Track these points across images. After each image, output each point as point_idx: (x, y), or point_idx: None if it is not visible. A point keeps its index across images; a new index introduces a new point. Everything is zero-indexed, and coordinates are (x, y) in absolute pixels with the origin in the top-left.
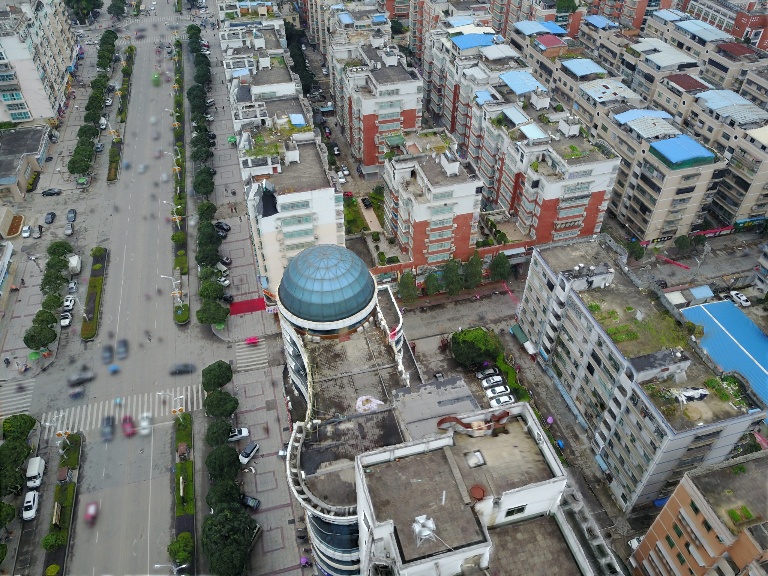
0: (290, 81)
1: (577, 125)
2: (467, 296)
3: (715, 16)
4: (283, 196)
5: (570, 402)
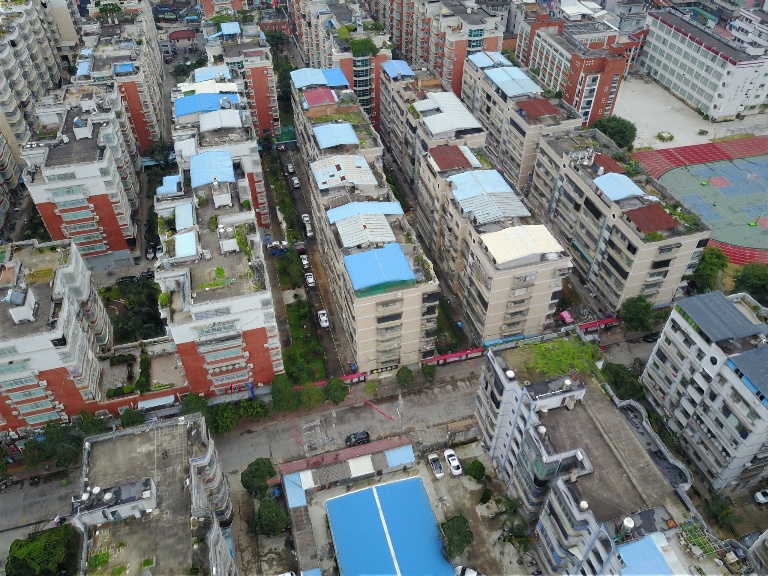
0: None
1: (231, 240)
2: None
3: (554, 56)
4: None
5: None
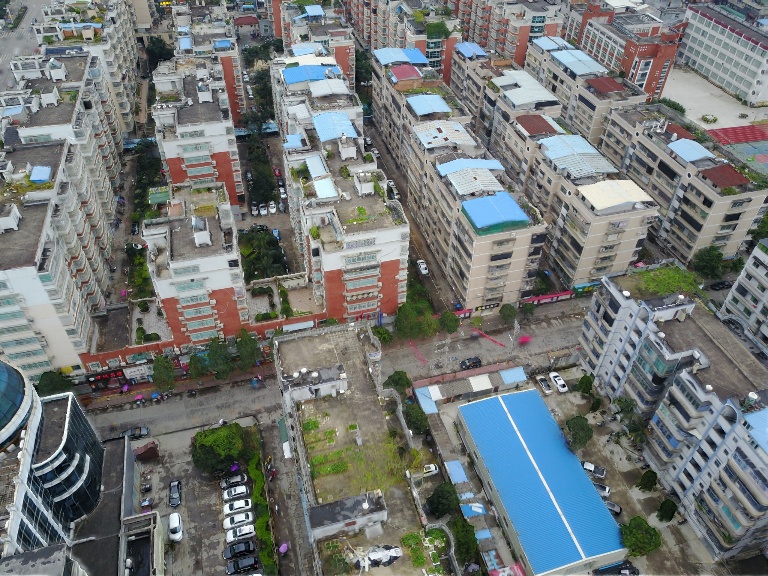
0: (70, 121)
1: (370, 183)
2: (248, 376)
3: (607, 43)
4: None
5: None
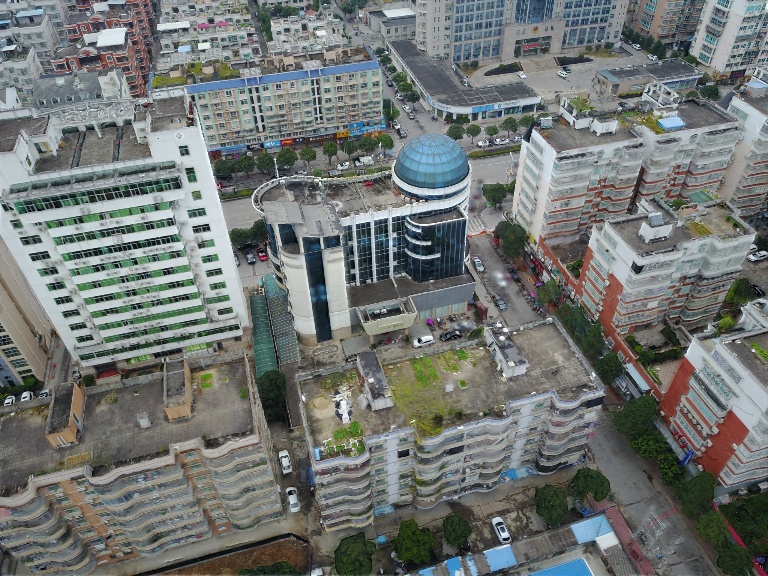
0: None
1: None
2: None
3: None
4: (535, 131)
5: None
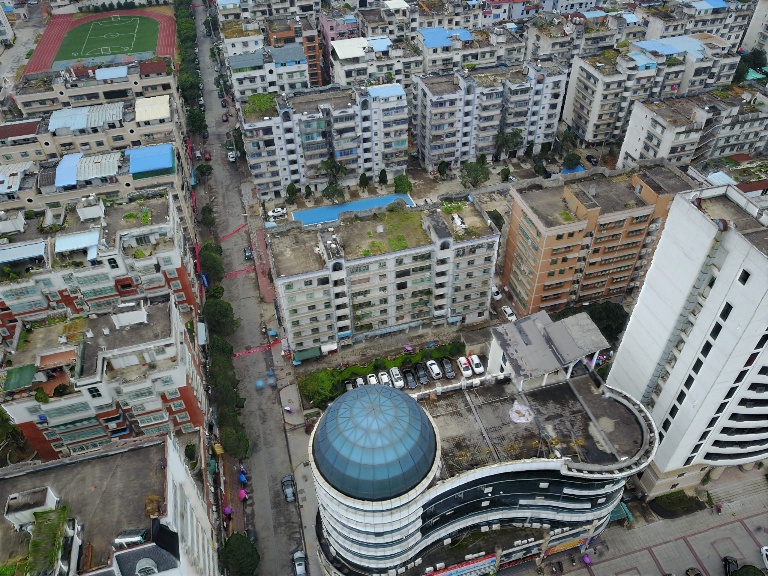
0: None
1: (100, 200)
2: None
3: None
4: (168, 508)
5: (395, 328)
